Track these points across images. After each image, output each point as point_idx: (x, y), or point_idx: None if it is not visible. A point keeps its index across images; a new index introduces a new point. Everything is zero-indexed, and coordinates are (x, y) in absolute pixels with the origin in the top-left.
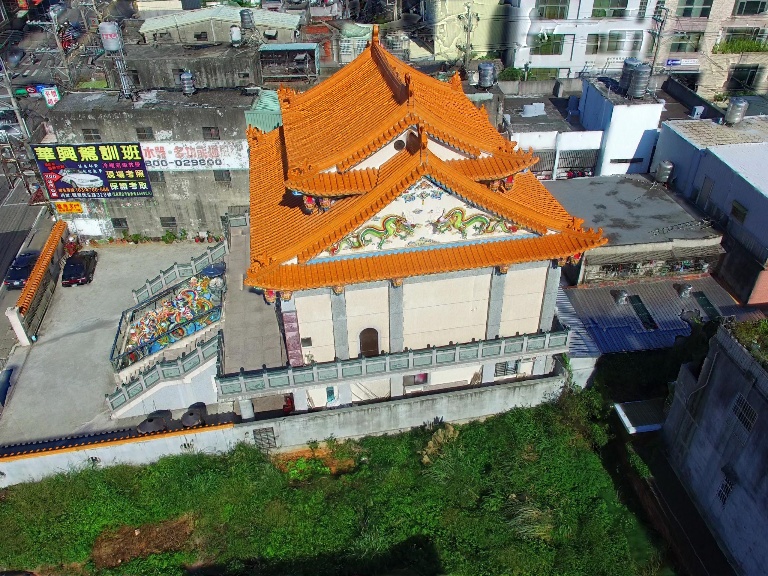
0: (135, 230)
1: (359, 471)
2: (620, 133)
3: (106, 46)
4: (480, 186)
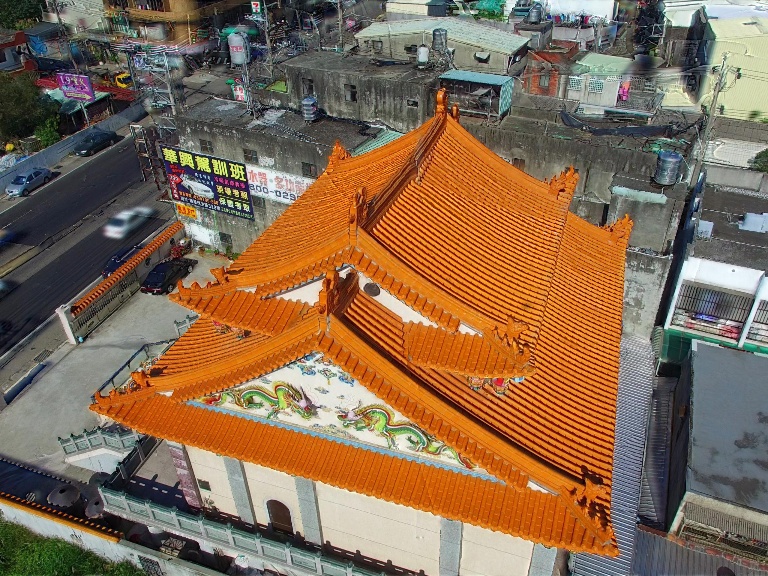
0: (238, 249)
1: None
2: None
3: (232, 58)
4: (417, 386)
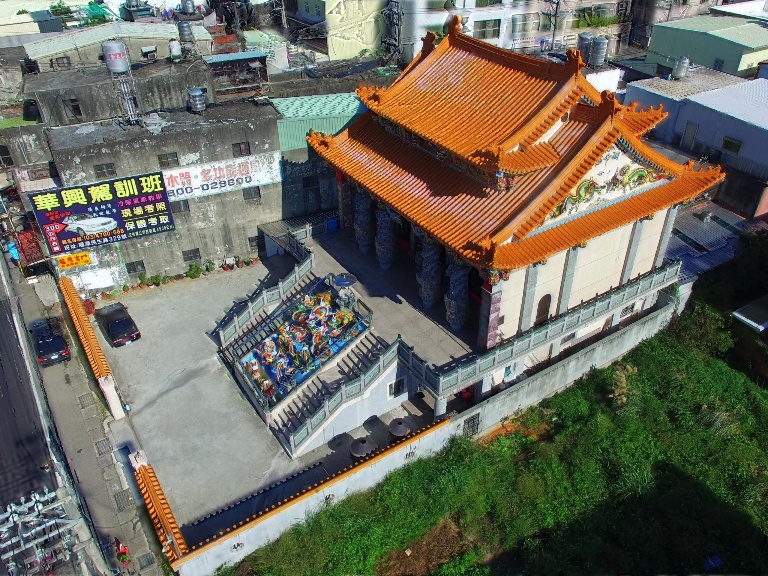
0: (153, 271)
1: (567, 429)
2: None
3: (113, 68)
4: None
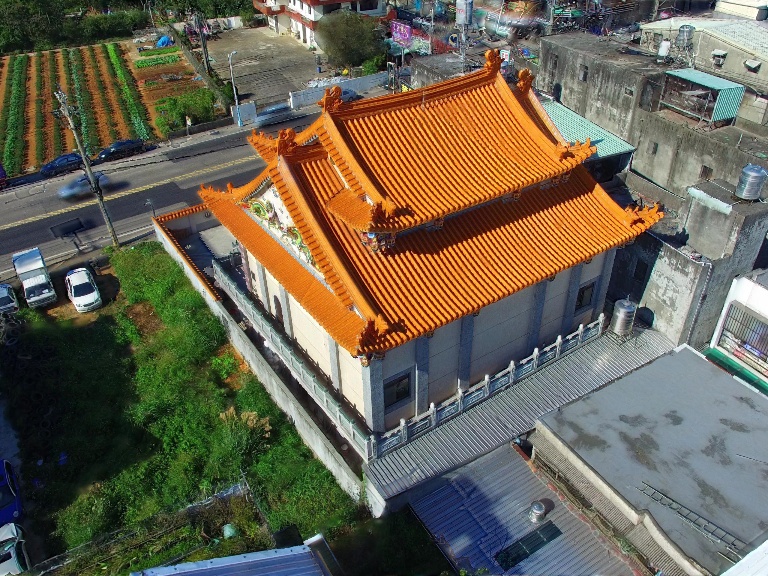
0: None
1: (219, 389)
2: None
3: None
4: (313, 217)
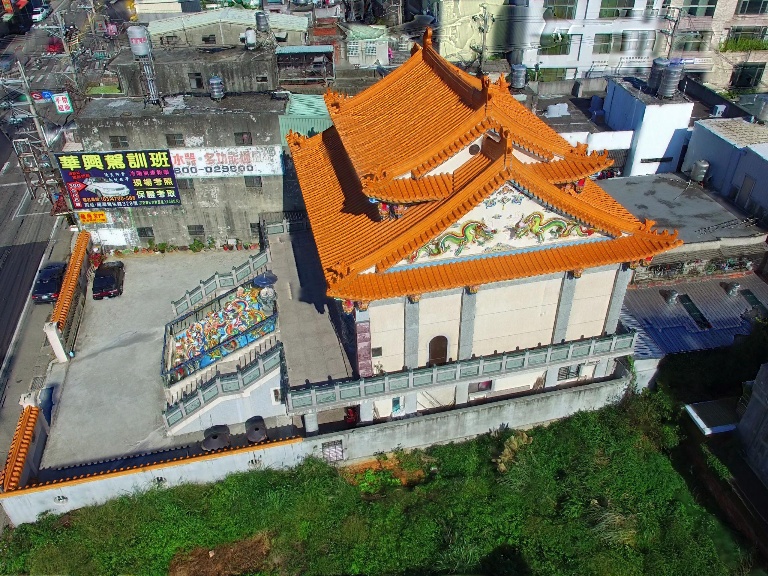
0: (161, 239)
1: (433, 482)
2: (651, 133)
3: (135, 51)
4: (559, 190)
